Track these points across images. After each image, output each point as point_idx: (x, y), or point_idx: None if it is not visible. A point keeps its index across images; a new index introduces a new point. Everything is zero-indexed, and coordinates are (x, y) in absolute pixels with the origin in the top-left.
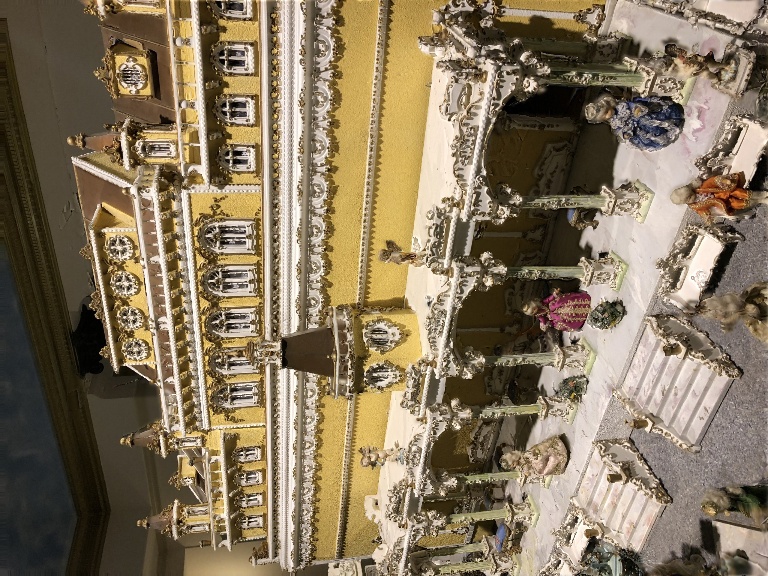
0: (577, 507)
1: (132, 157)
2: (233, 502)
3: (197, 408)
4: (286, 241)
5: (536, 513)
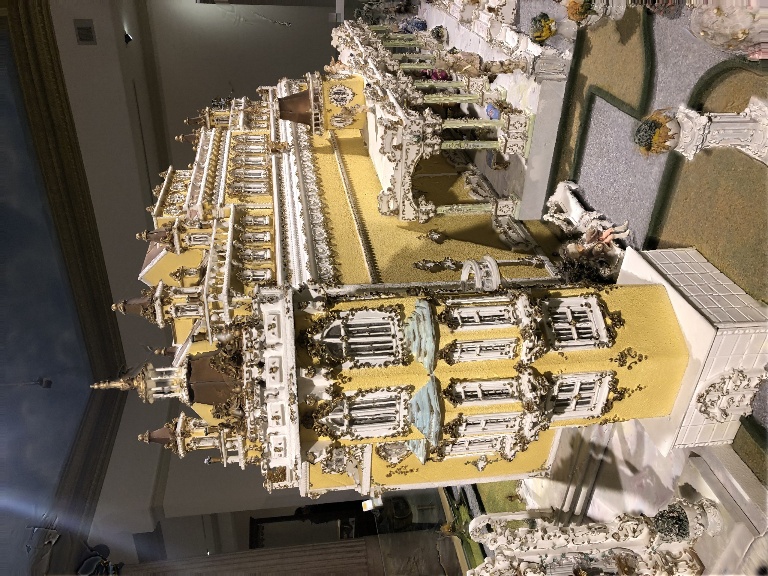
0: None
1: None
2: (237, 253)
3: None
4: None
5: (497, 86)
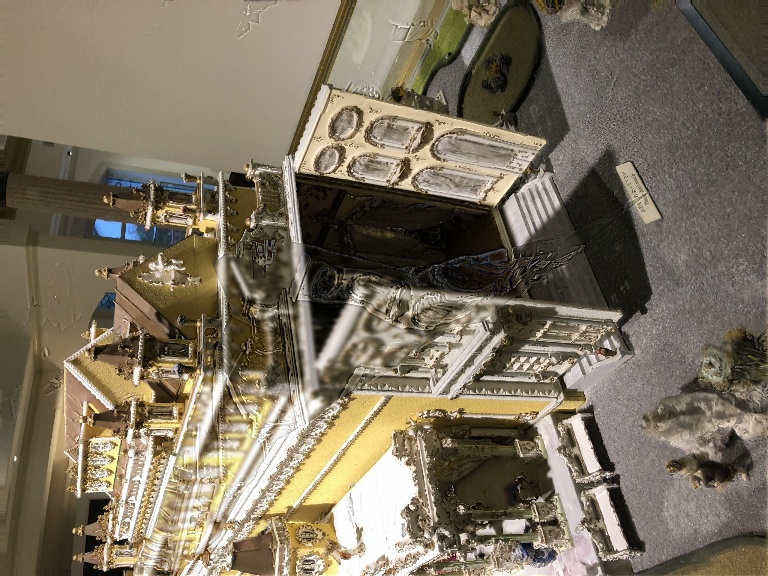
0: None
1: (135, 436)
2: None
3: (144, 529)
4: (250, 489)
5: None
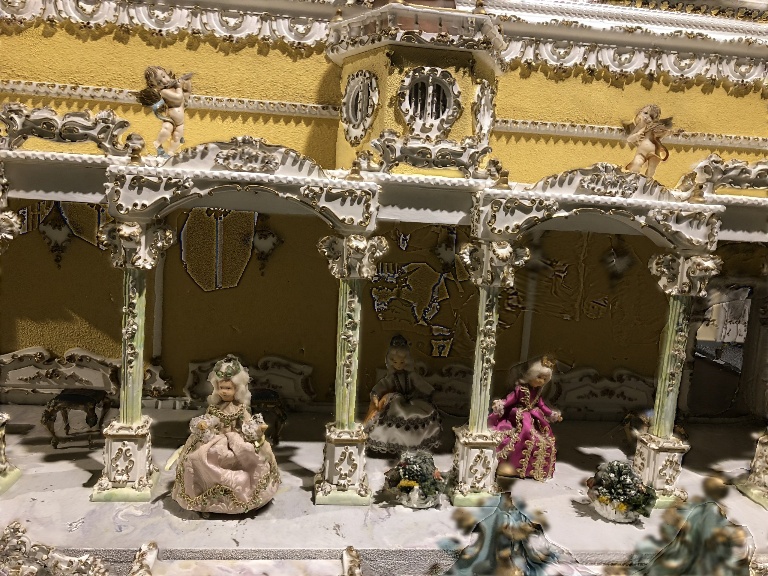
0: (148, 564)
1: None
2: None
3: None
4: (550, 4)
5: None
